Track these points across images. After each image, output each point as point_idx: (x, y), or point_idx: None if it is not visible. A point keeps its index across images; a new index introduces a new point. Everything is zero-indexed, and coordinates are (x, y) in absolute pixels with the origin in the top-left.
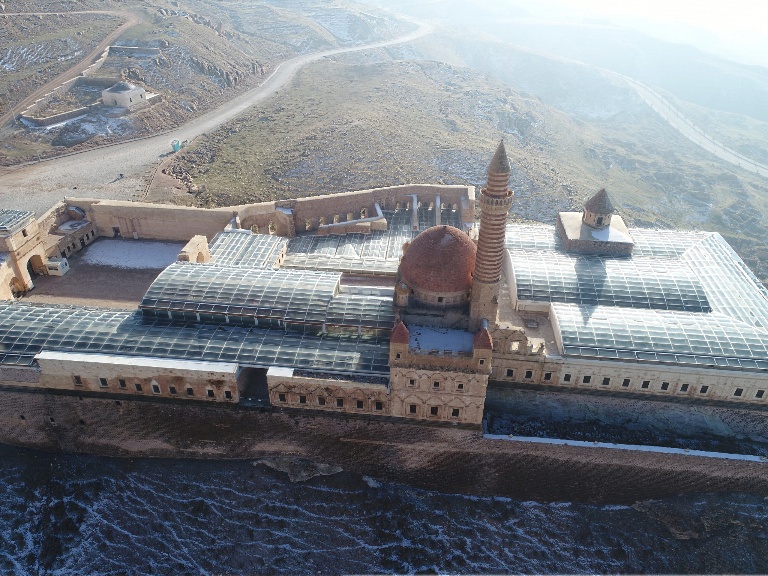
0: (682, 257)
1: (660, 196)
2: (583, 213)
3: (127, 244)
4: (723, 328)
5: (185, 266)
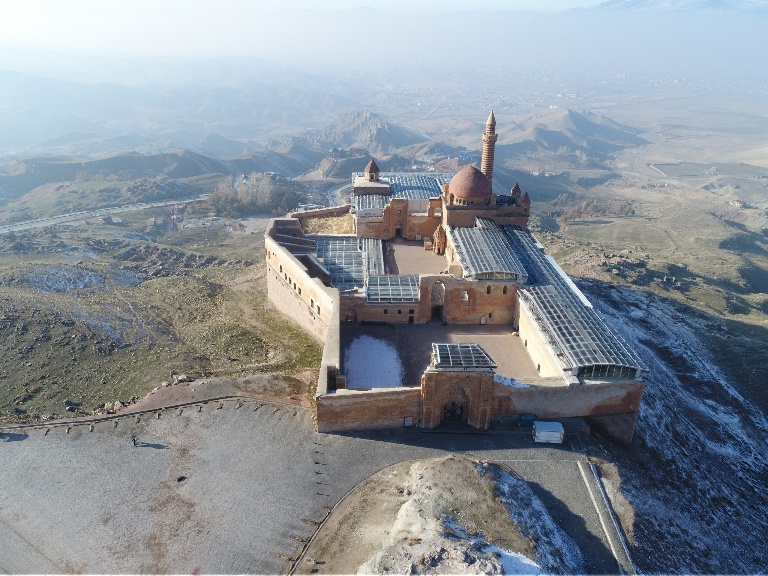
0: None
1: (59, 255)
2: (369, 177)
3: (353, 383)
4: None
5: None
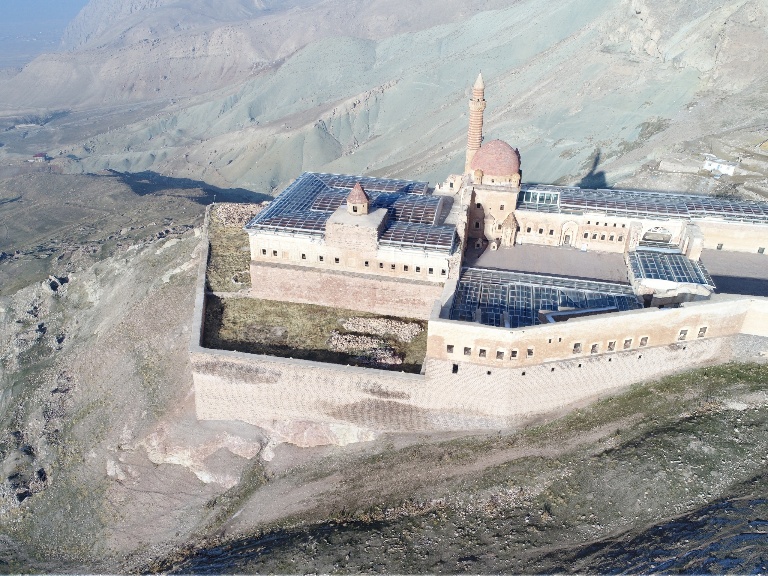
0: (306, 210)
1: None
2: (367, 209)
3: None
4: (338, 180)
5: (678, 213)
